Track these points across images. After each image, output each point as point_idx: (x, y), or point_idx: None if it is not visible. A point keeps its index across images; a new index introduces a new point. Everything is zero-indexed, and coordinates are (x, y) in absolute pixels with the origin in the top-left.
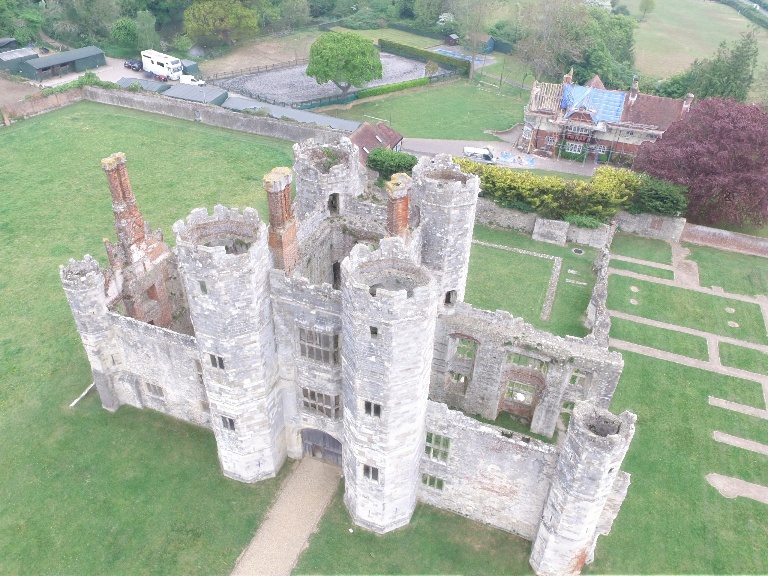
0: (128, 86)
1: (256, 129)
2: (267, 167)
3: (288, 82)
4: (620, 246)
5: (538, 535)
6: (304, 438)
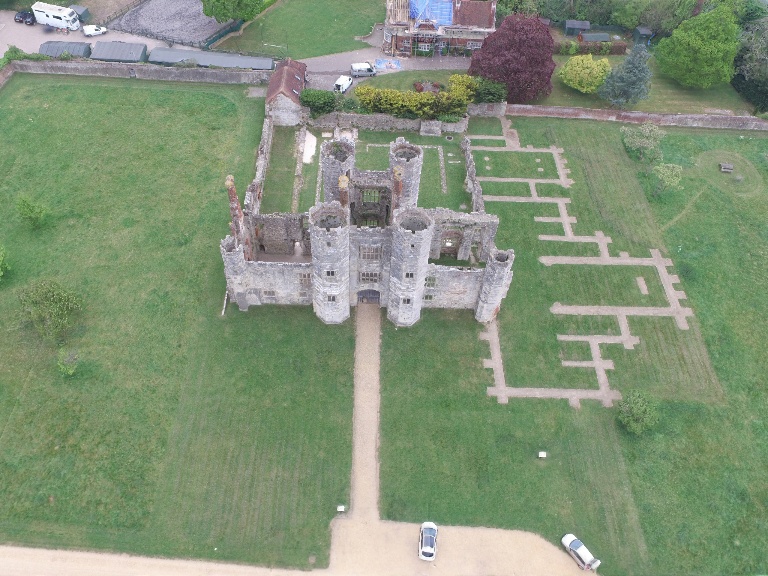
0: (59, 56)
1: (189, 78)
2: (220, 115)
3: (175, 12)
4: (472, 128)
5: (479, 306)
6: (359, 295)
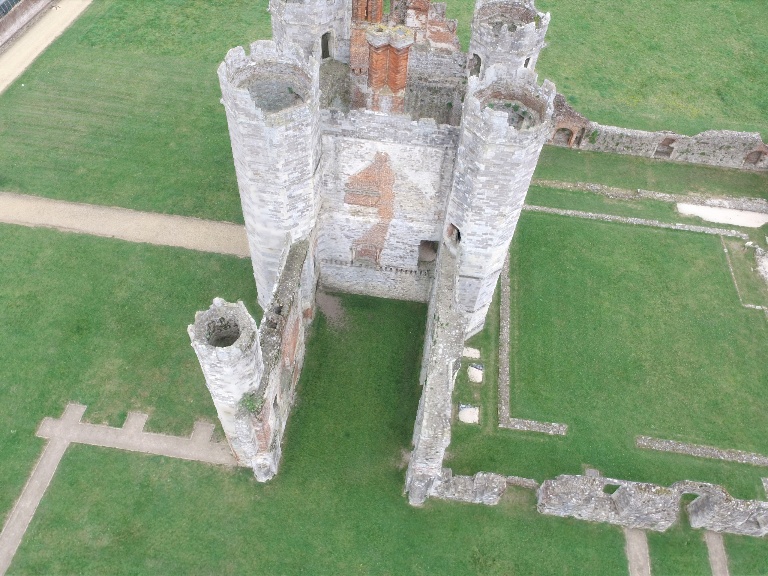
0: None
1: None
2: (760, 101)
3: None
4: None
5: None
6: None
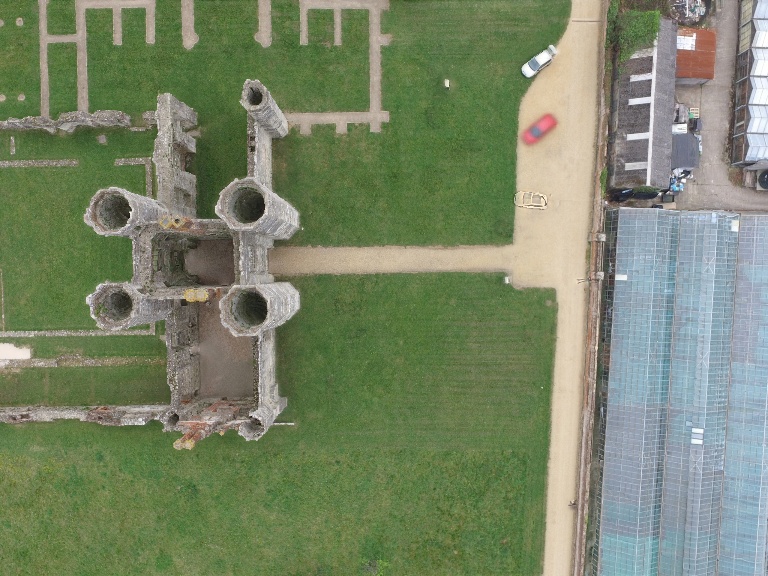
0: None
1: None
2: None
3: None
4: None
5: None
6: None
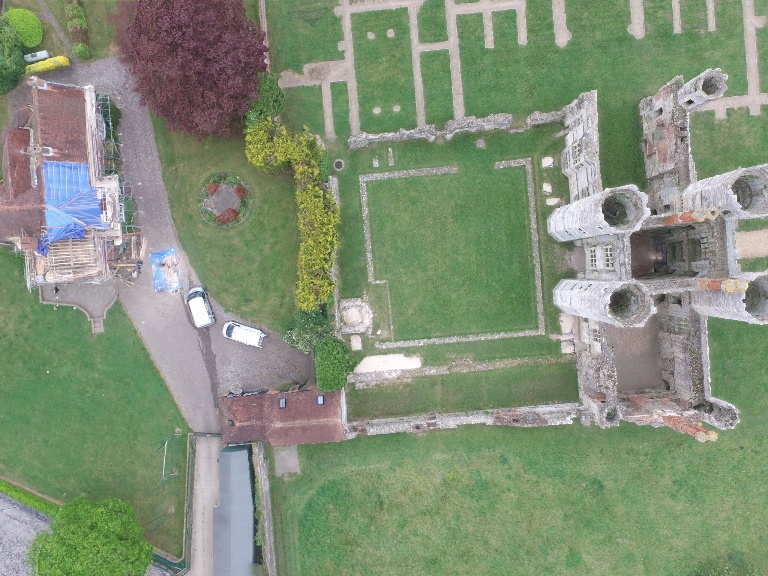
0: None
1: None
2: (349, 502)
3: None
4: (310, 132)
5: None
6: None
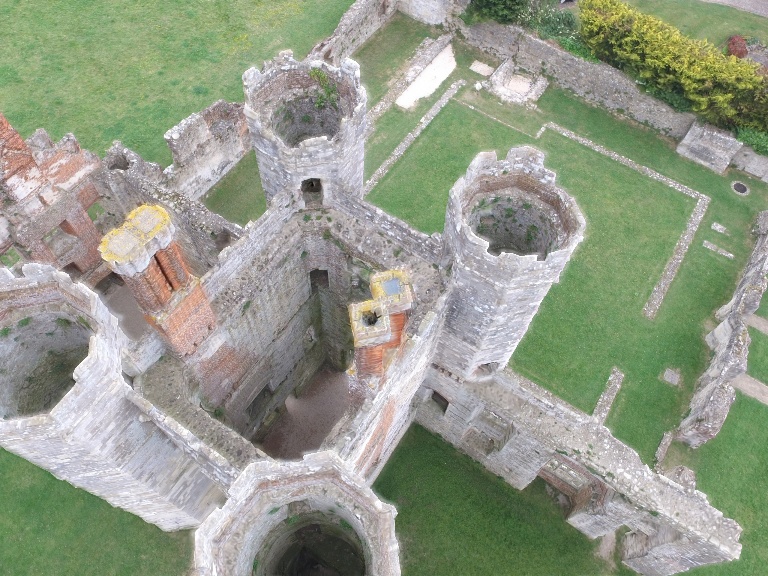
0: None
1: None
2: None
3: None
4: None
5: None
6: None
